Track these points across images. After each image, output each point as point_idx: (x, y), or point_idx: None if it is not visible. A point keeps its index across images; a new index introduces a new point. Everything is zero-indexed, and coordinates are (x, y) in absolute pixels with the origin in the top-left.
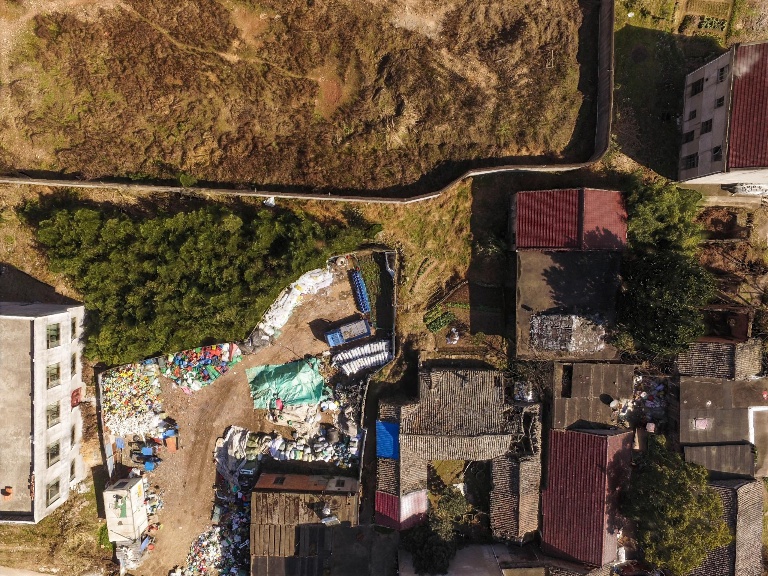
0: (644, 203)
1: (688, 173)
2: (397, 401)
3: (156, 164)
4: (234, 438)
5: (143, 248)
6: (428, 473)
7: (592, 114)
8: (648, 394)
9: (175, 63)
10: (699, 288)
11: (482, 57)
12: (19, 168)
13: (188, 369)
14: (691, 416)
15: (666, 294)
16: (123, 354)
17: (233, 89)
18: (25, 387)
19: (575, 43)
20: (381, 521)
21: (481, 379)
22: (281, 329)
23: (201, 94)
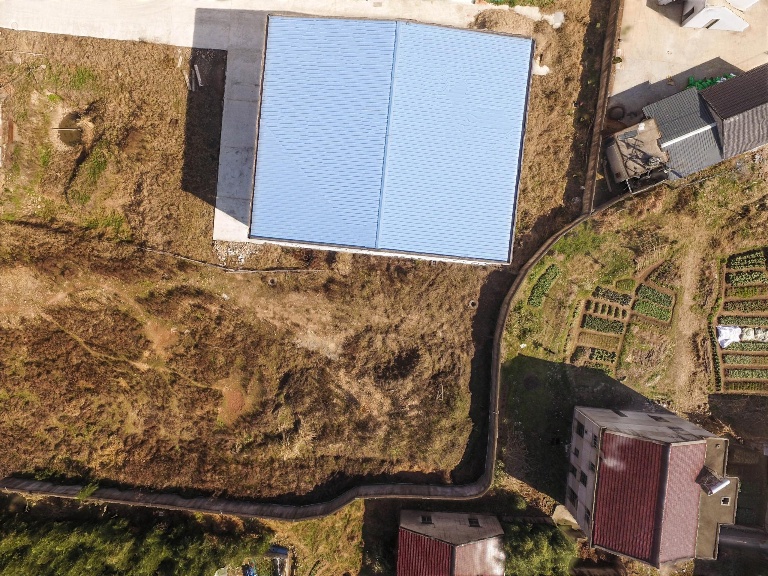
0: (517, 557)
1: (571, 507)
2: None
3: (64, 460)
4: None
5: None
6: None
7: (484, 435)
8: None
9: (88, 370)
10: None
11: (377, 384)
12: None
13: None
14: None
15: None
16: None
17: (141, 395)
18: None
19: (466, 375)
20: None
21: None
22: None
23: (111, 398)
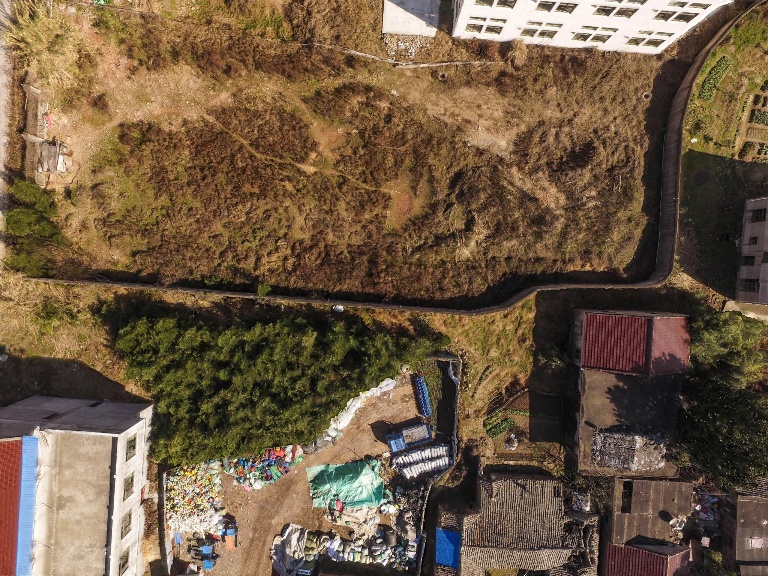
0: (709, 331)
1: (747, 296)
2: (458, 508)
3: (230, 268)
4: (293, 537)
5: (218, 356)
6: None
7: (654, 233)
8: (702, 506)
9: (254, 173)
10: None
11: (551, 178)
12: (95, 267)
13: (252, 470)
14: (747, 535)
15: (737, 433)
16: (193, 458)
17: (308, 198)
18: (103, 500)
19: (641, 168)
20: None
21: (541, 489)
22: (343, 429)
23: (277, 202)
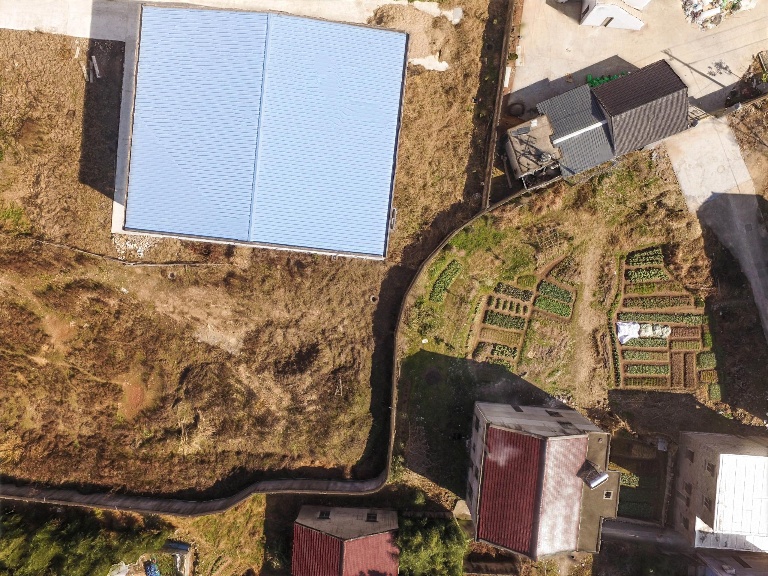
0: (407, 551)
1: (469, 502)
2: None
3: None
4: None
5: None
6: None
7: (386, 430)
8: None
9: None
10: None
11: (276, 379)
12: None
13: None
14: None
15: None
16: None
17: (40, 389)
18: None
19: (366, 370)
20: None
21: None
22: None
23: (8, 392)
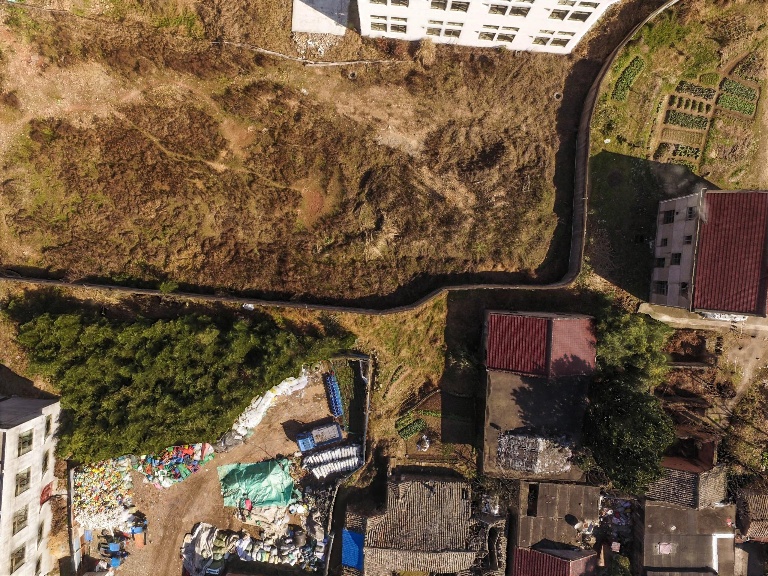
0: (612, 333)
1: (658, 298)
2: (365, 509)
3: (140, 265)
4: (202, 536)
5: (120, 353)
6: None
7: (567, 234)
8: (615, 510)
9: (163, 170)
10: (658, 436)
11: (461, 178)
12: (6, 263)
13: (160, 467)
14: (655, 540)
15: (627, 436)
16: (95, 455)
17: (218, 196)
18: None
19: (552, 168)
20: None
21: (449, 491)
22: (254, 428)
23: (187, 200)
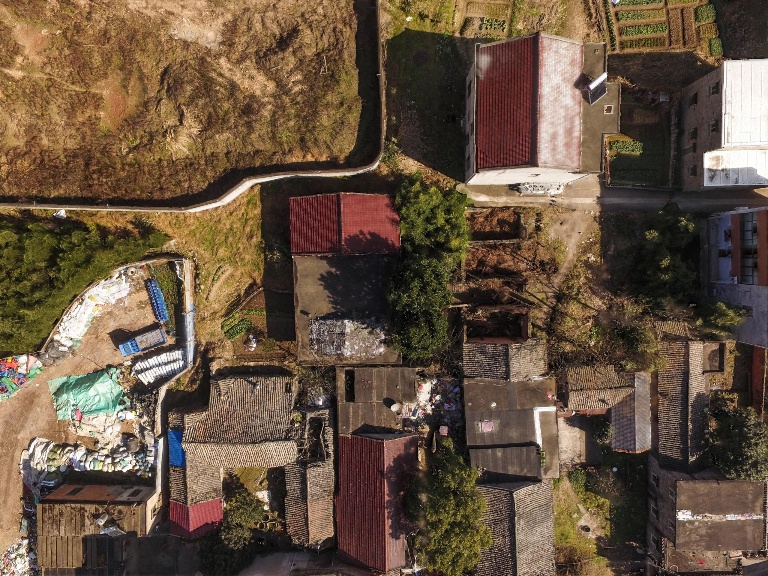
0: (407, 206)
1: (467, 174)
2: (189, 409)
3: None
4: (36, 450)
5: None
6: (231, 481)
7: (377, 118)
8: (446, 397)
9: None
10: (425, 290)
11: (258, 65)
12: None
13: None
14: (477, 418)
15: (403, 297)
16: None
17: (19, 104)
18: None
19: (350, 49)
20: (175, 530)
21: (272, 385)
22: (81, 340)
23: None
